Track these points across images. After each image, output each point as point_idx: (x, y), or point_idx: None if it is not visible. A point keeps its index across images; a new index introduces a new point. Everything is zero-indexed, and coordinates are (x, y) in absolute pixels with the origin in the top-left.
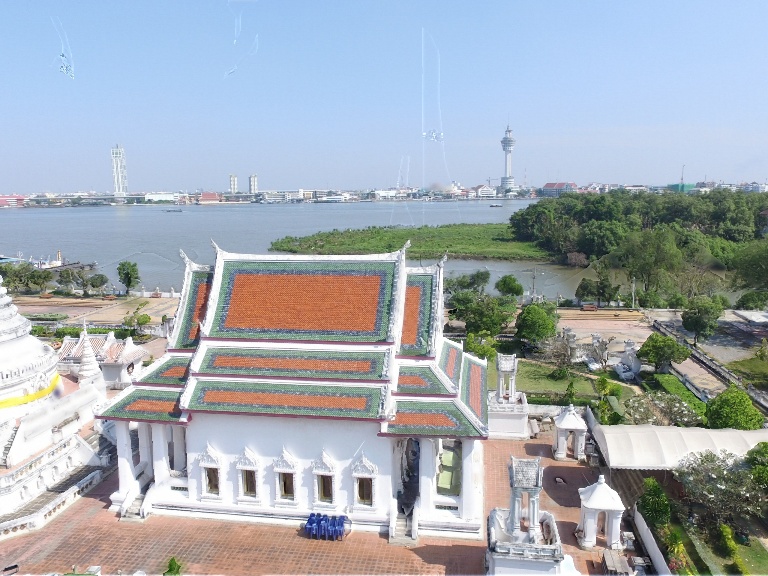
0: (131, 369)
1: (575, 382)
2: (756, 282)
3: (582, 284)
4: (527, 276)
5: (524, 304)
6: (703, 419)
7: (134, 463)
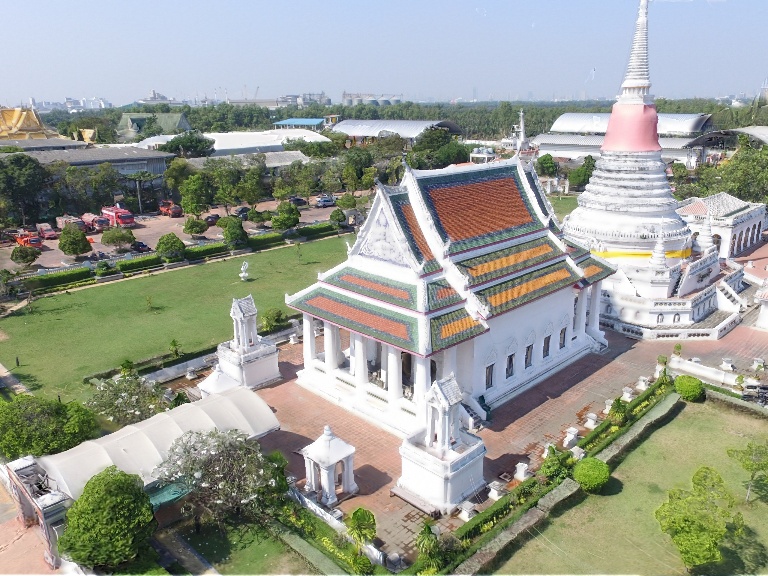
0: None
1: None
2: None
3: None
4: None
5: None
6: None
7: None
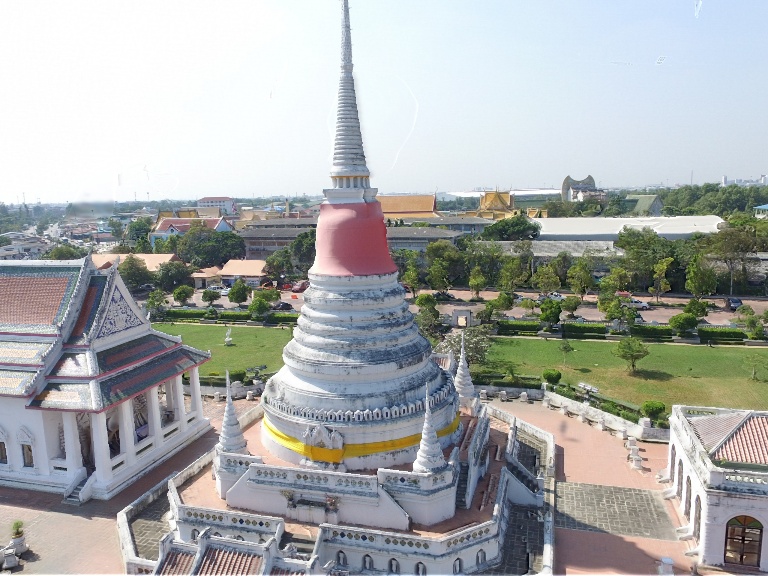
0: None
1: None
2: None
3: None
4: None
5: None
6: None
7: None
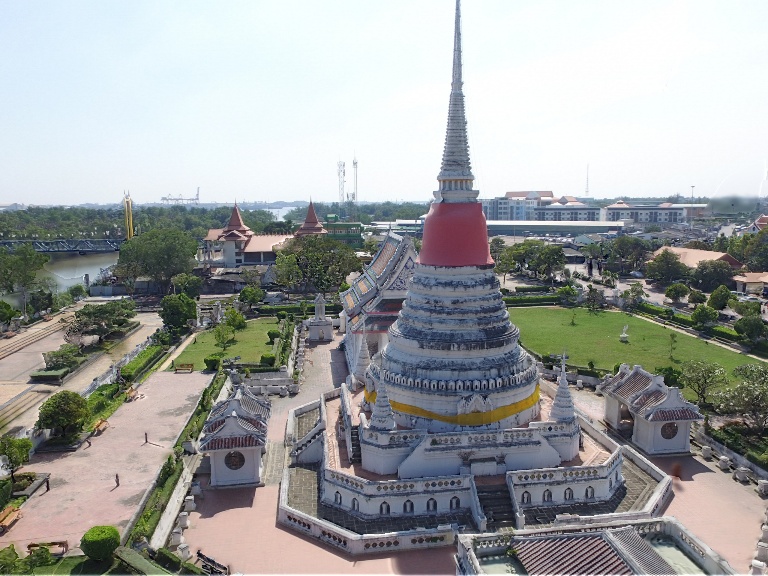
0: None
1: (251, 325)
2: (150, 267)
3: (35, 298)
4: (15, 298)
5: (3, 331)
6: (329, 305)
7: None
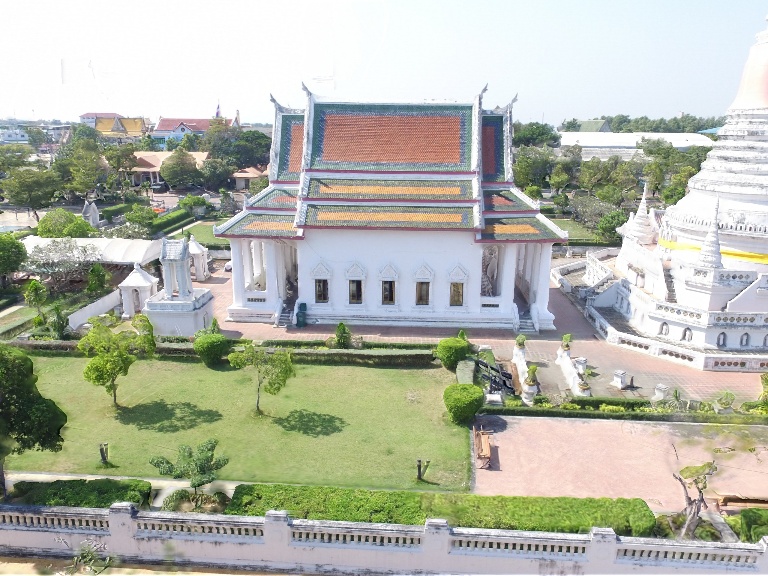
0: None
1: None
2: None
3: None
4: None
5: None
6: None
7: (566, 304)
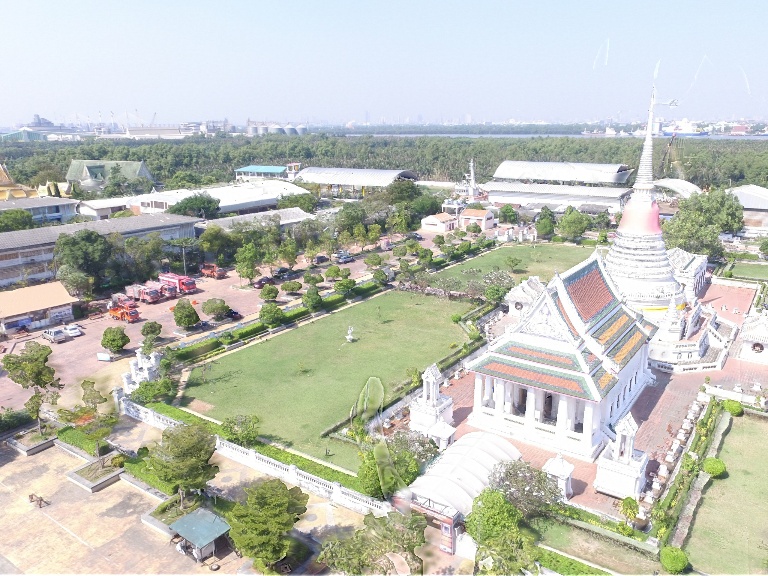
0: (760, 349)
1: None
2: None
3: None
4: None
5: None
6: None
7: None
